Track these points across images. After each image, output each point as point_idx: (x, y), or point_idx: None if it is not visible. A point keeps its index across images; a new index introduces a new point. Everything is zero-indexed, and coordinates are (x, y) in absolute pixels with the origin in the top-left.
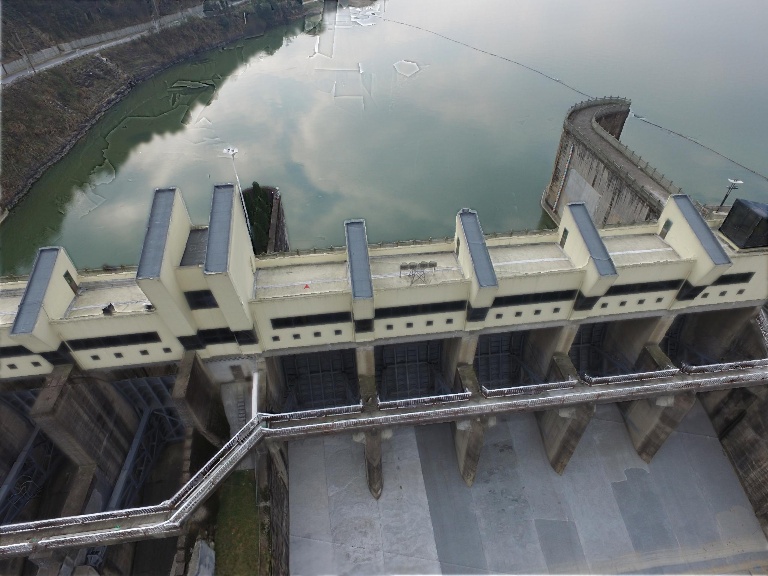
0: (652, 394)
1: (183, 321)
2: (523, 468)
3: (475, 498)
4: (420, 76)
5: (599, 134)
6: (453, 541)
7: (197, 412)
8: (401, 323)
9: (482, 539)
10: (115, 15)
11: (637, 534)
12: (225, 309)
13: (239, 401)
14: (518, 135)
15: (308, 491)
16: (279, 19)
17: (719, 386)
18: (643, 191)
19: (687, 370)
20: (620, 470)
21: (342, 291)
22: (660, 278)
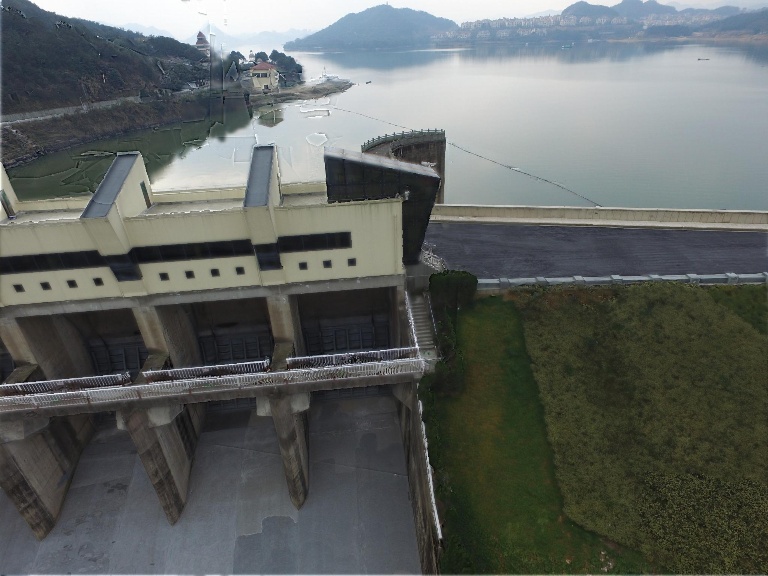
0: (221, 393)
1: None
2: (127, 515)
3: (39, 556)
4: None
5: (389, 156)
6: None
7: None
8: None
9: None
10: (44, 98)
11: None
12: None
13: None
14: None
15: None
16: None
17: (319, 384)
18: None
19: None
20: (257, 518)
21: None
22: (217, 237)
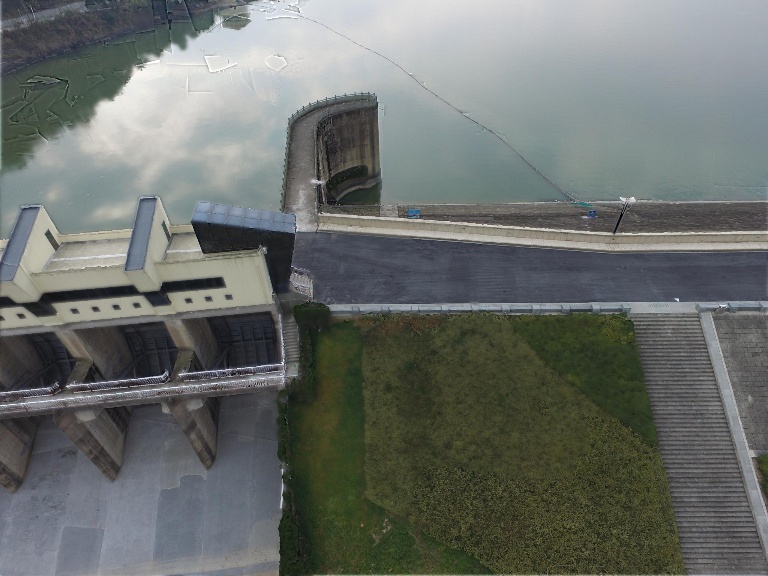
0: (129, 402)
1: None
2: (77, 474)
3: (13, 504)
4: (296, 71)
5: None
6: None
7: None
8: None
9: (1, 546)
10: None
11: (163, 542)
12: None
13: None
14: None
15: None
16: None
17: (204, 394)
18: None
19: None
20: (176, 477)
21: None
22: (112, 284)
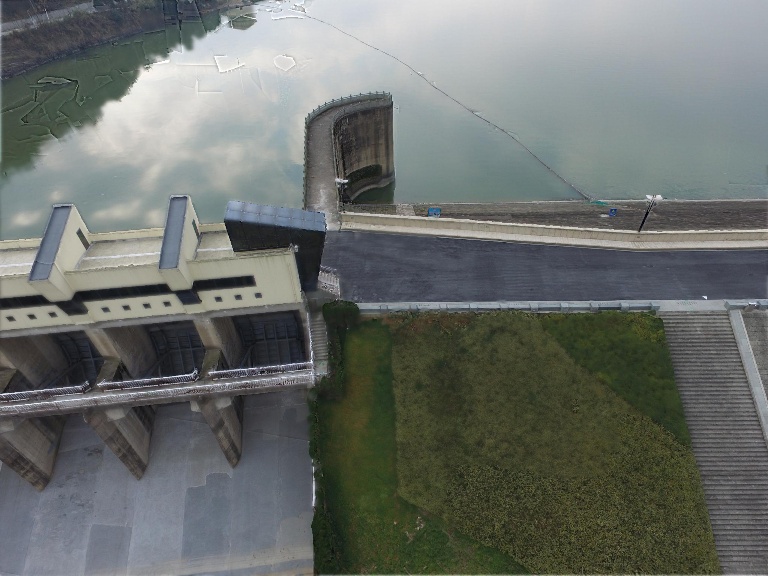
0: (159, 400)
1: None
2: (104, 472)
3: (41, 503)
4: (305, 70)
5: None
6: None
7: None
8: None
9: (30, 544)
10: None
11: (191, 540)
12: None
13: None
14: None
15: None
16: None
17: (234, 392)
18: None
19: None
20: (202, 475)
21: None
22: (143, 282)
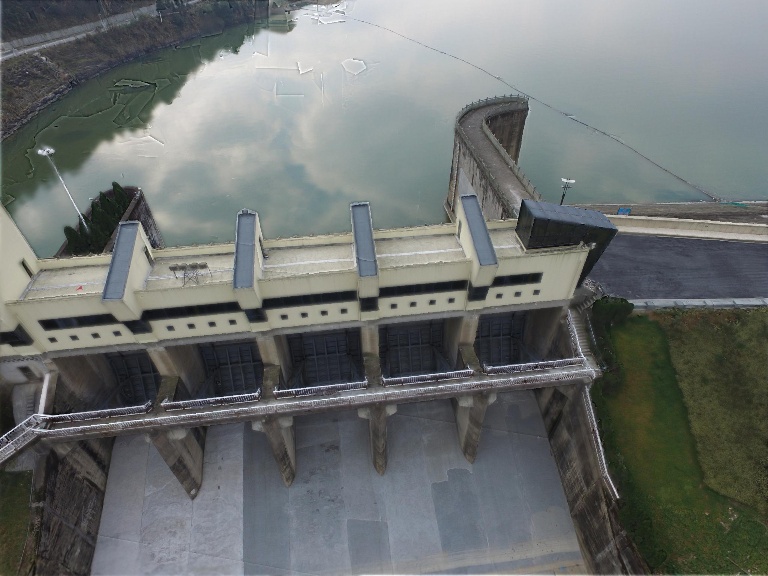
0: (444, 395)
1: None
2: (345, 468)
3: (291, 498)
4: (370, 74)
5: (485, 133)
6: (261, 541)
7: None
8: (181, 324)
9: (291, 539)
10: (61, 14)
11: (448, 534)
12: None
13: (28, 402)
14: (441, 133)
15: (125, 491)
16: (239, 17)
17: (514, 387)
18: (499, 190)
19: (486, 371)
20: (443, 470)
21: (102, 293)
22: (442, 279)
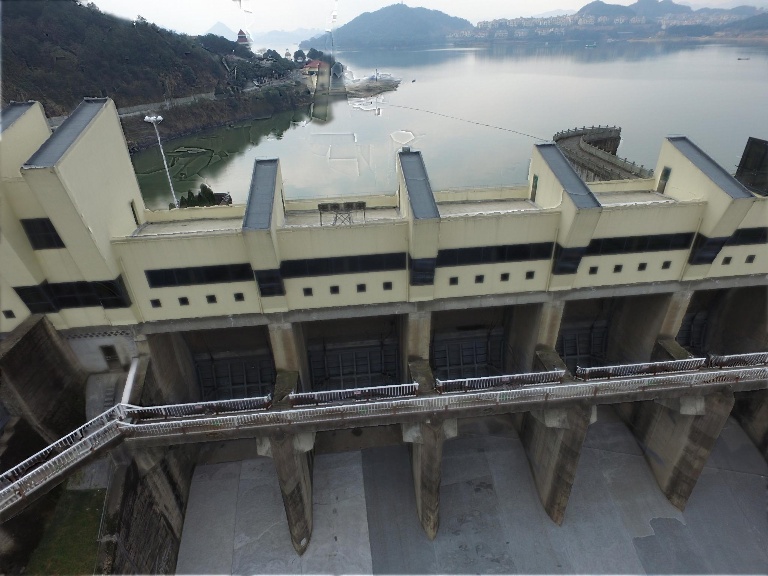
0: (672, 391)
1: (14, 258)
2: (507, 515)
3: (439, 556)
4: (416, 146)
5: (588, 152)
6: None
7: (26, 393)
8: (322, 286)
9: None
10: (129, 94)
11: None
12: (68, 239)
13: (107, 395)
14: (509, 180)
15: (207, 541)
16: (287, 105)
17: (765, 382)
18: None
19: (717, 362)
20: (644, 520)
21: (236, 230)
22: (662, 229)
